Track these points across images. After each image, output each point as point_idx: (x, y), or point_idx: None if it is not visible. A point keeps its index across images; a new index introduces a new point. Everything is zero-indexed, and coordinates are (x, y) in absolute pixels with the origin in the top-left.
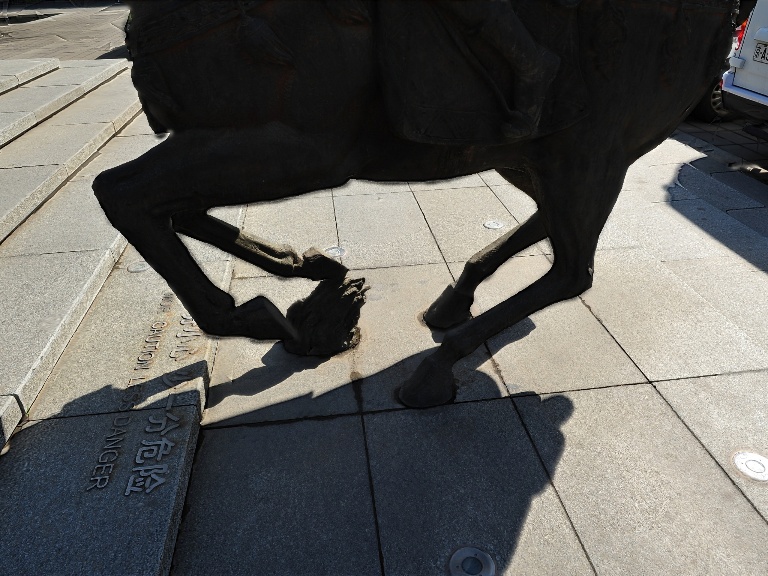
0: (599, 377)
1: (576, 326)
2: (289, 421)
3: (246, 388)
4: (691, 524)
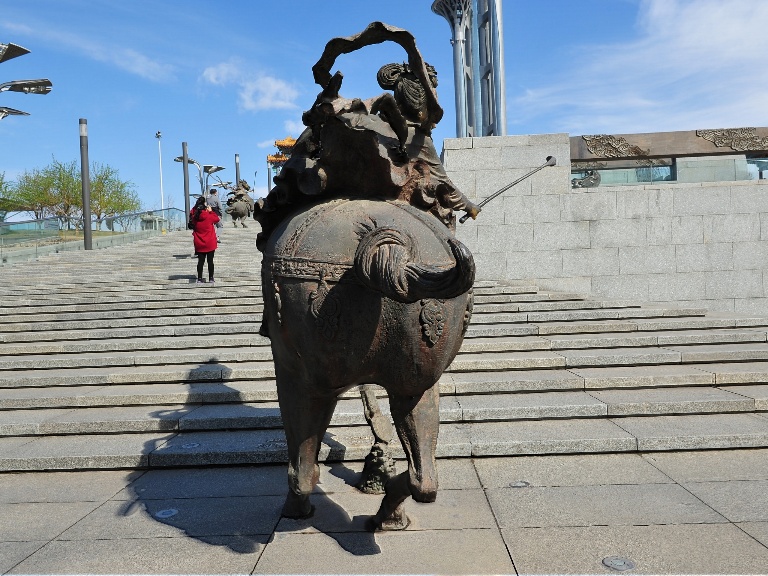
0: (267, 569)
1: (347, 574)
2: None
3: (336, 470)
4: None
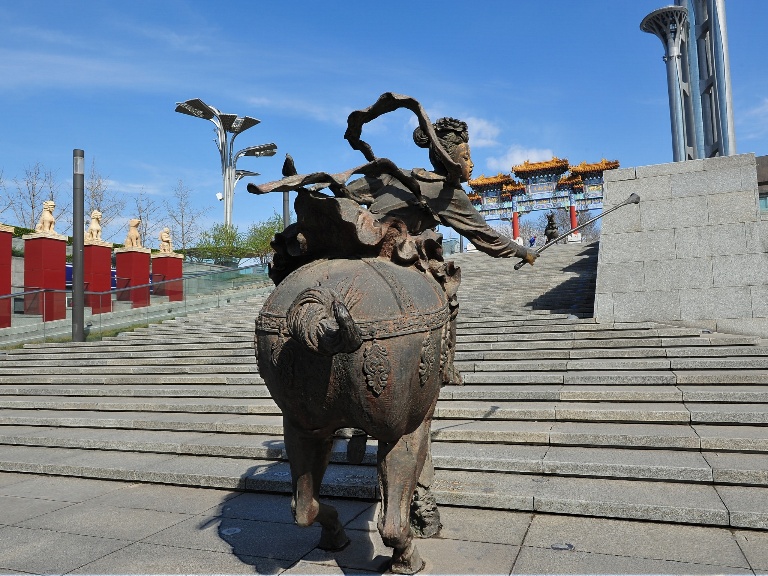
0: None
1: None
2: (358, 515)
3: None
4: (162, 572)
